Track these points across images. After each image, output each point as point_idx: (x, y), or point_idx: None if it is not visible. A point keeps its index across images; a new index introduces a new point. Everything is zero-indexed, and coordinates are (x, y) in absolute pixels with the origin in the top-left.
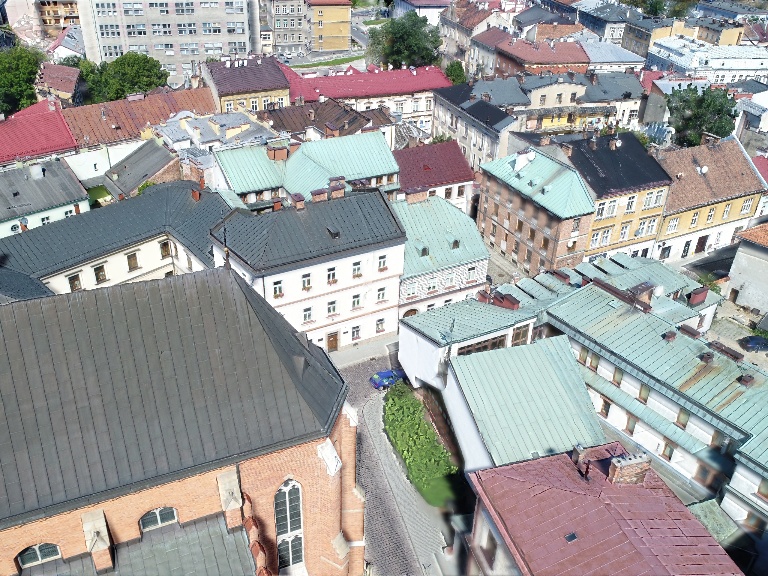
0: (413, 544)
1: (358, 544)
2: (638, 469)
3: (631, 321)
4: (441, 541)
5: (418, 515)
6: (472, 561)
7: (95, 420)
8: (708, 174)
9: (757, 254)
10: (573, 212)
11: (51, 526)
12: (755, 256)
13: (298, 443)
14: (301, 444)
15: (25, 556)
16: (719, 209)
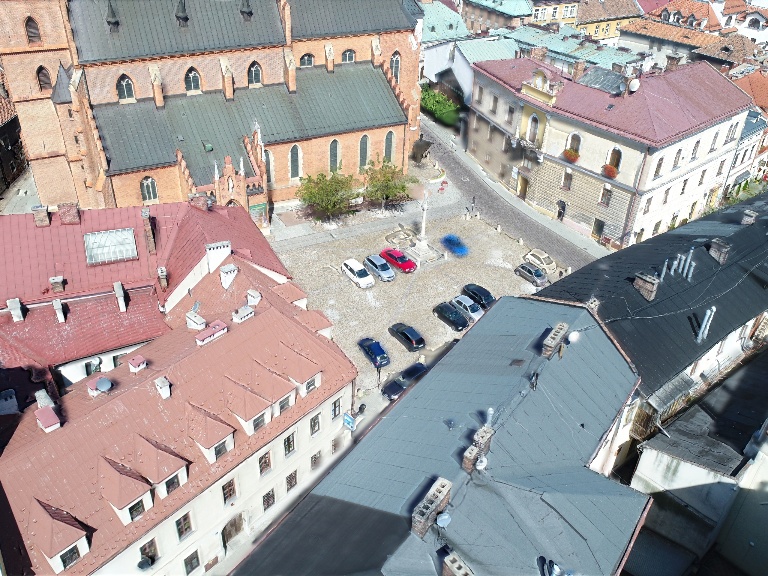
0: (440, 138)
1: (417, 118)
2: (542, 52)
3: (547, 36)
4: (454, 137)
5: (441, 131)
6: (471, 115)
7: (329, 6)
8: (606, 3)
9: (629, 39)
10: (520, 13)
11: (314, 45)
12: (628, 41)
13: (402, 29)
14: (403, 31)
15: (302, 62)
16: (613, 25)
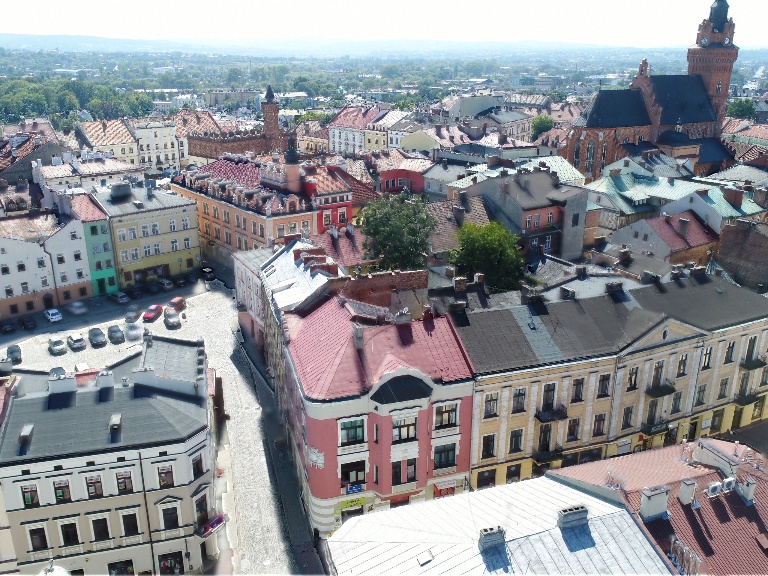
0: None
1: None
2: None
3: None
4: None
5: None
6: None
7: None
8: None
9: None
10: None
11: None
12: None
13: None
14: None
15: None
16: None
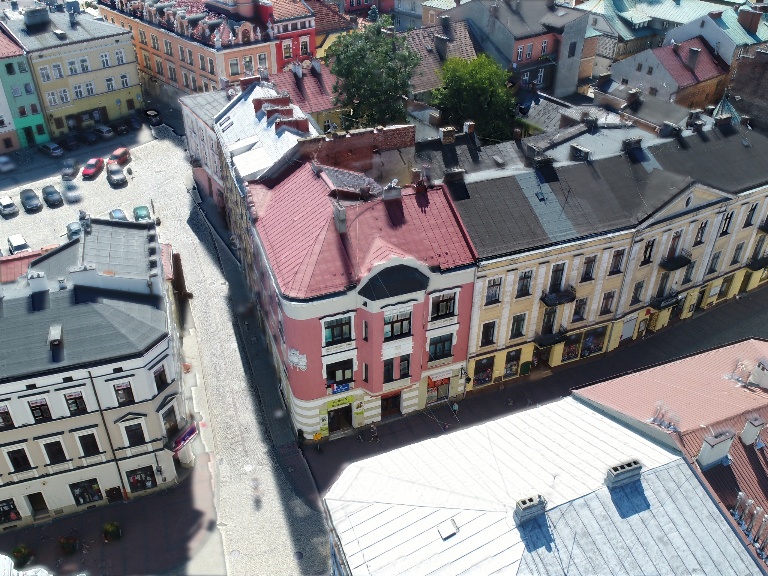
0: None
1: None
2: None
3: None
4: None
5: None
6: None
7: None
8: None
9: None
10: None
11: None
12: None
13: None
14: None
15: None
16: None
